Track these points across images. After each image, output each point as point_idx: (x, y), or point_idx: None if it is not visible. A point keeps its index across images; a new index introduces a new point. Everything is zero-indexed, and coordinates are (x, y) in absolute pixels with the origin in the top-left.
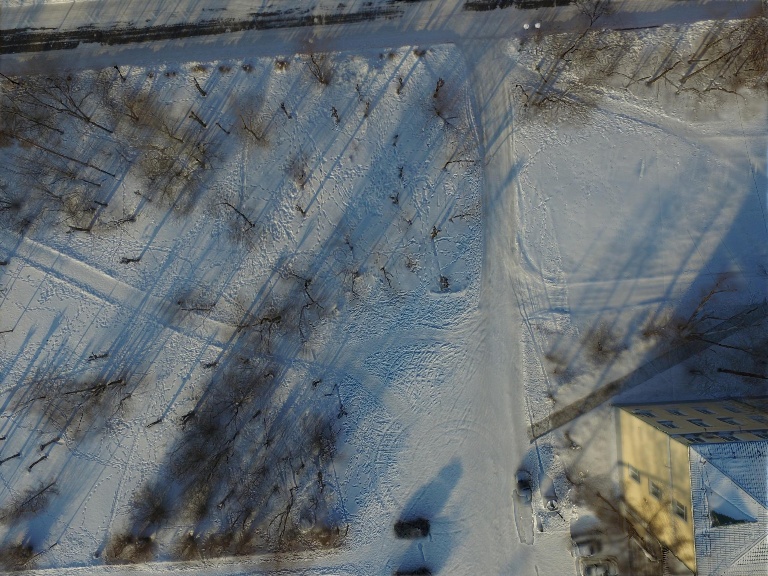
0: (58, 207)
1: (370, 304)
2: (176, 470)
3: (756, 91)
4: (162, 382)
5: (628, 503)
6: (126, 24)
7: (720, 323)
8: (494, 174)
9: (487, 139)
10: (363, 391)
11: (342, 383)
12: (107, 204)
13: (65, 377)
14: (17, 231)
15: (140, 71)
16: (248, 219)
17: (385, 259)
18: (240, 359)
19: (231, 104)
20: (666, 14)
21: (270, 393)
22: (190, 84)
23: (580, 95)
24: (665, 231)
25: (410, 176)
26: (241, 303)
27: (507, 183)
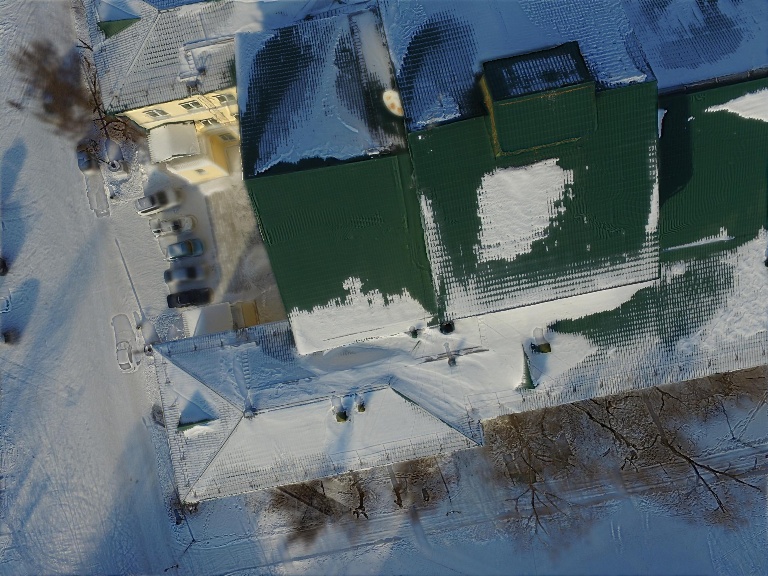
0: None
1: None
2: None
3: None
4: None
5: None
6: None
7: None
8: None
9: None
10: None
11: None
12: None
13: None
14: None
15: None
16: None
17: None
18: None
19: None
20: None
21: None
22: None
23: None
24: None
25: None
26: None
27: None
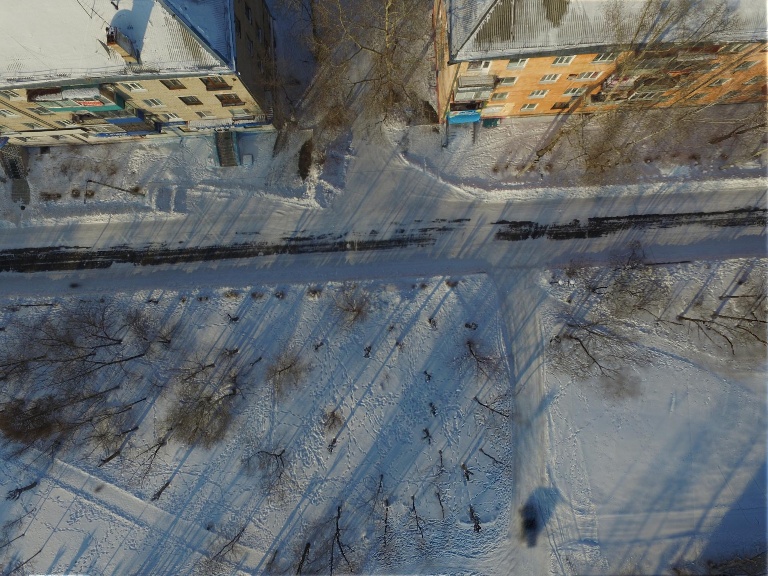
0: (89, 429)
1: (399, 531)
2: None
3: None
4: None
5: None
6: (159, 245)
7: (750, 559)
8: (524, 403)
9: (518, 368)
10: None
11: None
12: (138, 427)
13: None
14: (47, 452)
15: (173, 294)
16: (278, 445)
17: (415, 488)
18: None
19: (263, 330)
20: (697, 248)
21: None
22: (222, 308)
23: (611, 327)
24: (695, 466)
25: (441, 405)
26: (270, 529)
27: (537, 413)
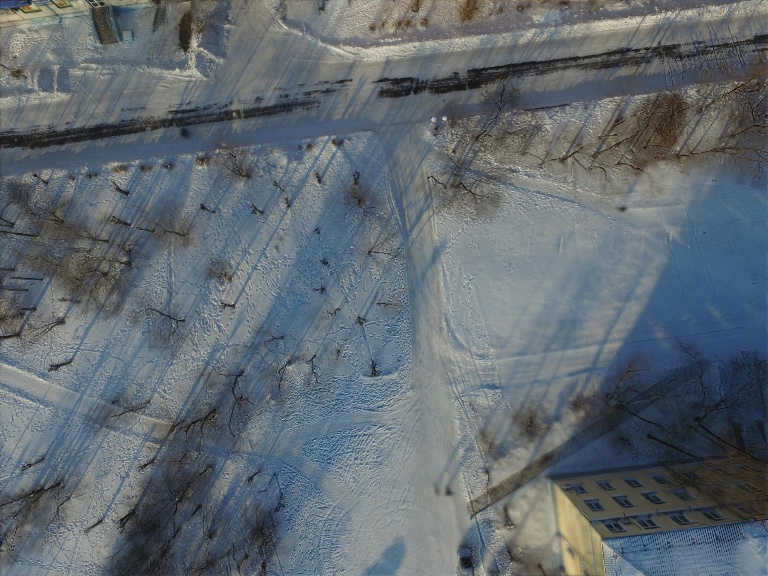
0: None
1: (304, 391)
2: (117, 573)
3: (665, 162)
4: (101, 482)
5: (567, 575)
6: (46, 127)
7: (647, 389)
8: (418, 256)
9: (409, 222)
10: (302, 478)
11: (281, 471)
12: (36, 308)
13: (3, 483)
14: None
15: (62, 174)
16: (178, 315)
17: (316, 346)
18: (178, 454)
19: (155, 202)
20: (575, 91)
21: (210, 486)
22: (113, 184)
23: (497, 175)
24: (587, 303)
25: (336, 263)
26: (176, 398)
27: (431, 264)
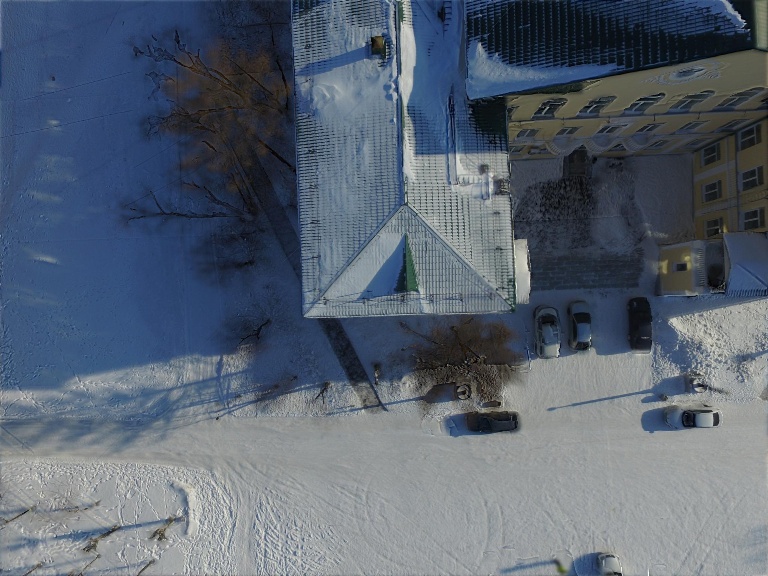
0: None
1: None
2: None
3: None
4: None
5: None
6: None
7: (241, 169)
8: (45, 443)
9: (1, 450)
10: None
11: None
12: None
13: None
14: None
15: None
16: None
17: None
18: None
19: None
20: None
21: None
22: None
23: None
24: (124, 234)
25: (39, 554)
26: None
27: (57, 428)
